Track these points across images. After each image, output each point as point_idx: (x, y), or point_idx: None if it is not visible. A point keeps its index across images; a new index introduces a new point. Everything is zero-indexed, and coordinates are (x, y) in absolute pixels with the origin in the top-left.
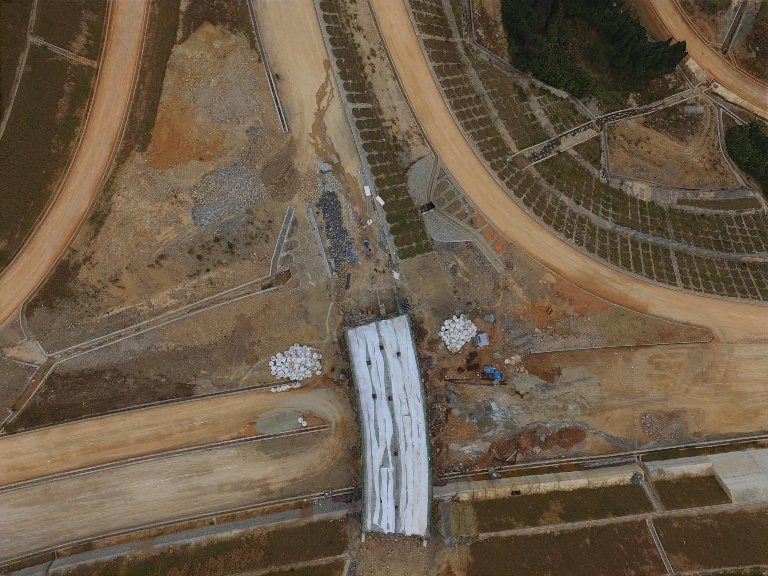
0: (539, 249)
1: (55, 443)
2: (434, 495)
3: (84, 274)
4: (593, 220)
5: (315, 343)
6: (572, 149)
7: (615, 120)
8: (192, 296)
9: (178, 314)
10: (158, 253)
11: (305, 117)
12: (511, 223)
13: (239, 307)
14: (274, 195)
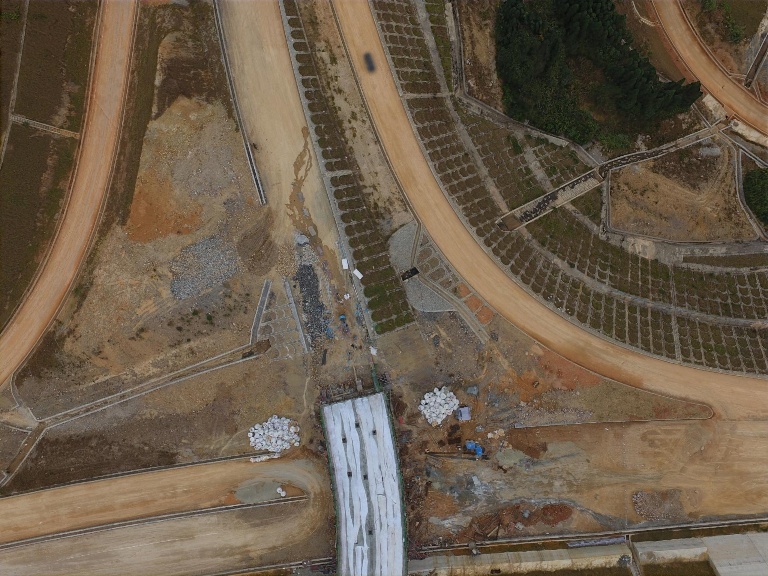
0: (526, 319)
1: (46, 506)
2: (411, 571)
3: (69, 346)
4: (588, 284)
5: (293, 415)
6: (570, 203)
7: (621, 166)
8: (174, 365)
9: (161, 382)
10: (138, 326)
11: (283, 187)
12: (497, 292)
13: (220, 376)
14: (251, 268)
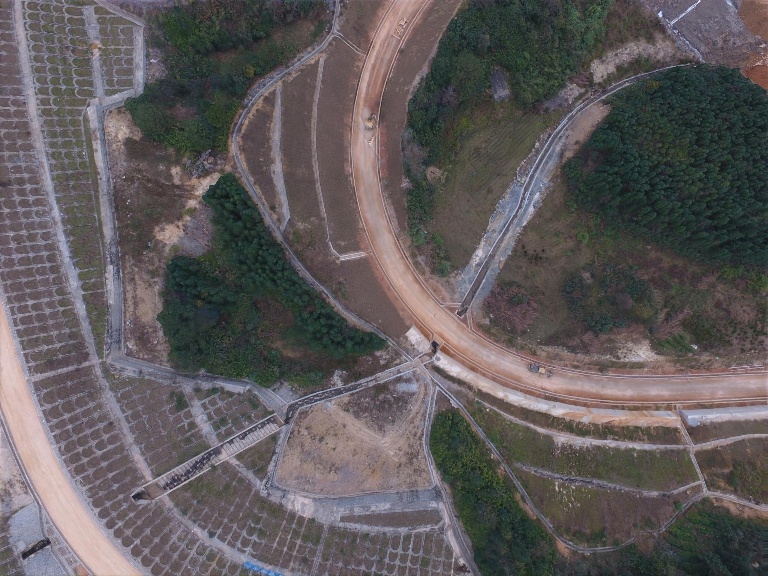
0: None
1: None
2: None
3: None
4: (227, 553)
5: None
6: (234, 458)
7: (312, 403)
8: None
9: None
10: None
11: None
12: (115, 574)
13: None
14: None
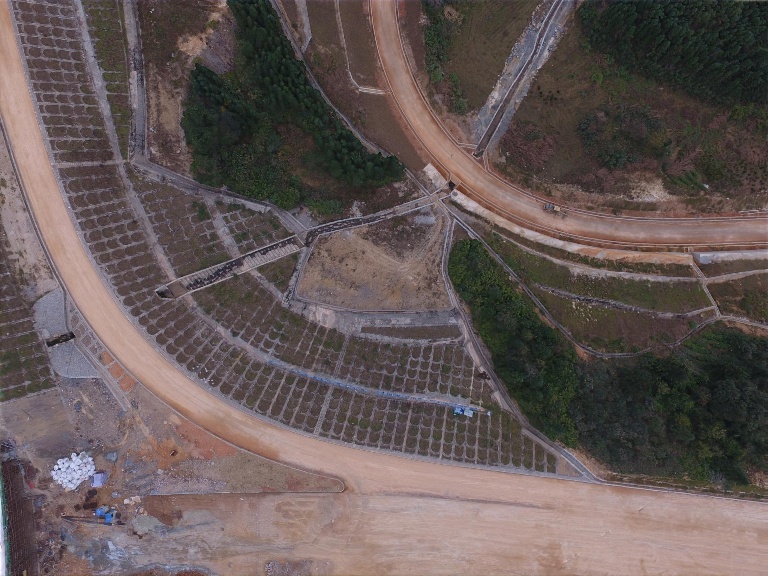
0: (168, 389)
1: None
2: None
3: None
4: (250, 353)
5: None
6: (255, 270)
7: (331, 231)
8: None
9: None
10: None
11: None
12: (140, 361)
13: None
14: None
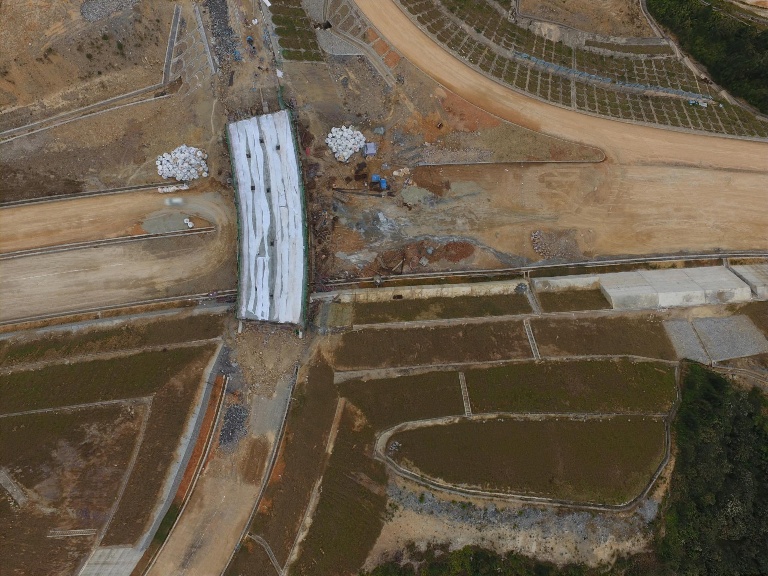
0: (431, 65)
1: None
2: None
3: None
4: (493, 49)
5: (202, 145)
6: None
7: None
8: (84, 98)
9: (71, 117)
10: (46, 47)
11: None
12: (404, 38)
13: (131, 112)
14: None
